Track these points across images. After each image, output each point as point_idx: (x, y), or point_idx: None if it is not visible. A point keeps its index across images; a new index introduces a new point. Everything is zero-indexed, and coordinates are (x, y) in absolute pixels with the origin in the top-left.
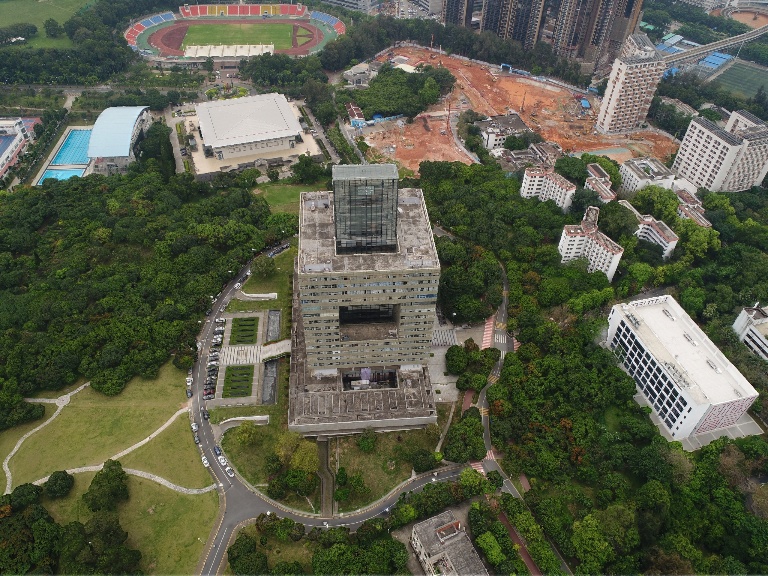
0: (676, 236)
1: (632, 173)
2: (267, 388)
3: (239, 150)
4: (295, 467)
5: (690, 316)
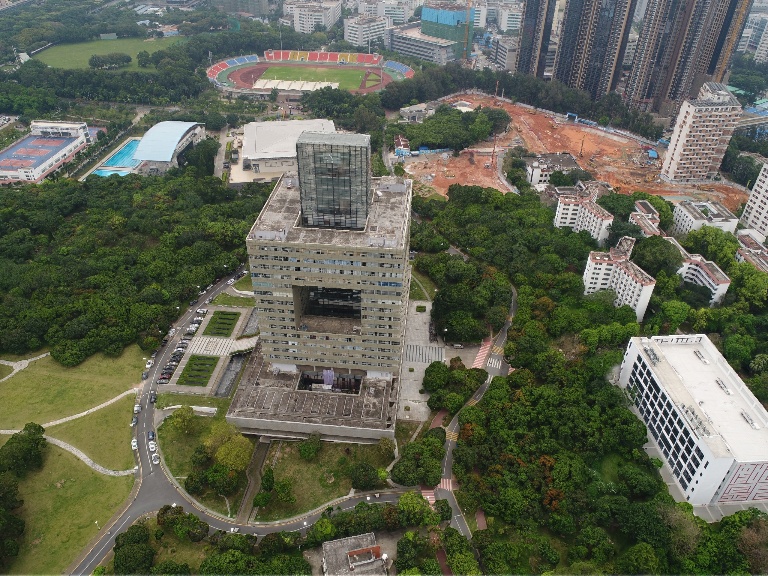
0: (728, 278)
1: (687, 213)
2: (226, 381)
3: (276, 165)
4: (219, 461)
5: (732, 366)
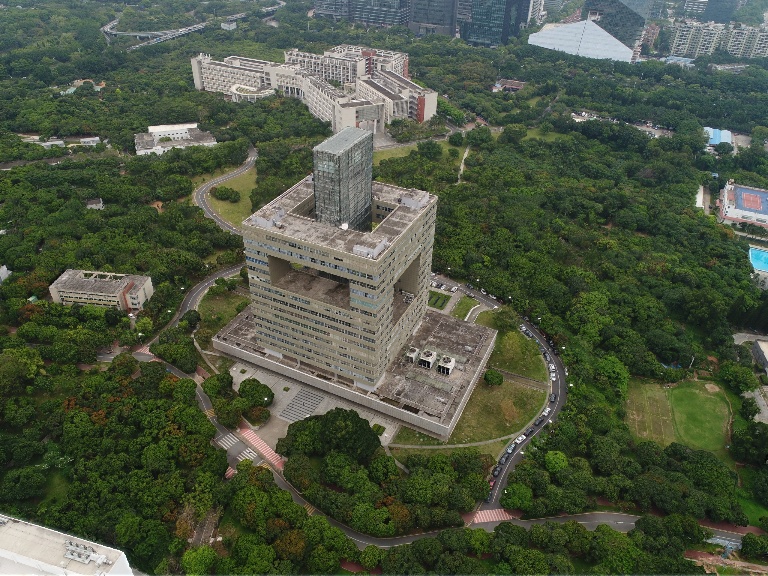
0: None
1: None
2: None
3: None
4: None
5: None
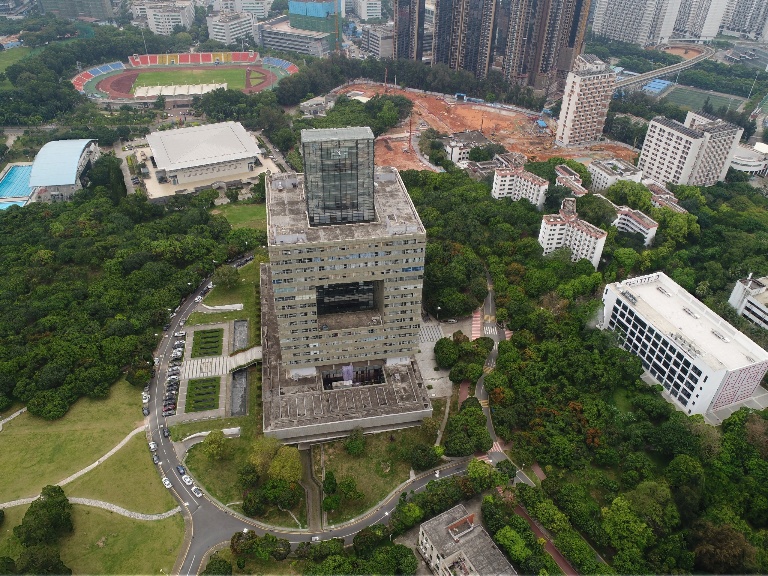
0: (655, 222)
1: (600, 171)
2: (236, 399)
3: (195, 174)
4: (274, 476)
5: None
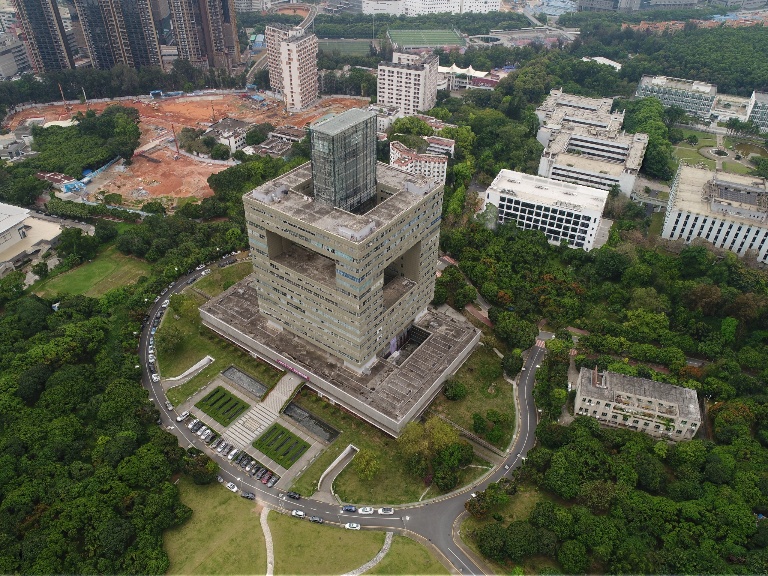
0: (452, 140)
1: None
2: (315, 429)
3: None
4: (443, 447)
5: None
